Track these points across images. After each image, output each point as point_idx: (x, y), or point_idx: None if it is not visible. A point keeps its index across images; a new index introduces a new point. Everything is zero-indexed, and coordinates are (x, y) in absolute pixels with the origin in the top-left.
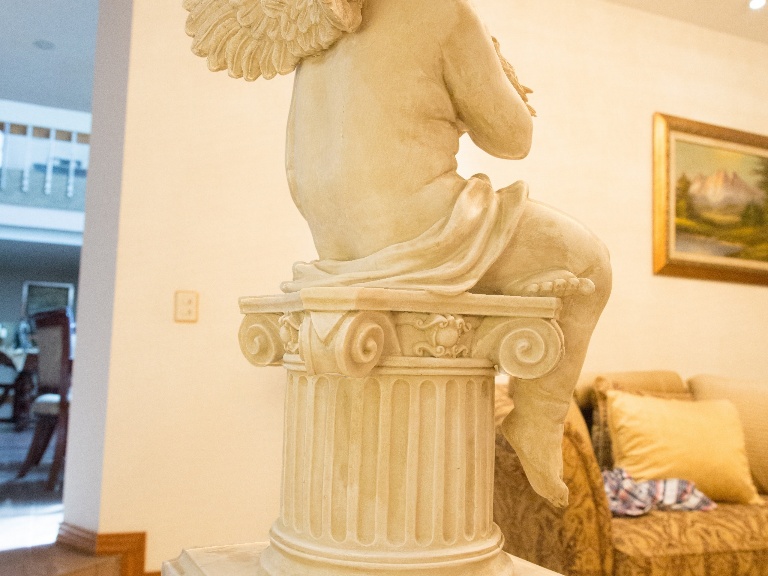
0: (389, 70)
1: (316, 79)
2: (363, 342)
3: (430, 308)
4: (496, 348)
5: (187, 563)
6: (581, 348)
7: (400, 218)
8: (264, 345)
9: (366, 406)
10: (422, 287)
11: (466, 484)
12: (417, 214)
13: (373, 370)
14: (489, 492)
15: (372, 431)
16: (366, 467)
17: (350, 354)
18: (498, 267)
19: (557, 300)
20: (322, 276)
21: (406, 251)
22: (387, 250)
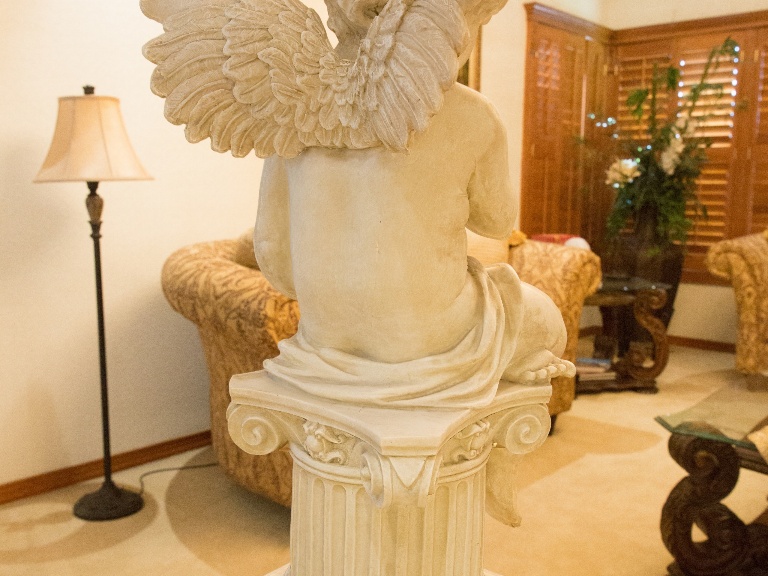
0: (432, 190)
1: (334, 176)
2: None
3: (470, 421)
4: (501, 432)
5: None
6: None
7: (433, 332)
8: (265, 436)
9: (411, 512)
10: (466, 406)
11: None
12: (449, 327)
13: None
14: None
15: (416, 532)
16: (411, 564)
17: None
18: None
19: None
20: (336, 374)
21: (443, 367)
22: (422, 364)
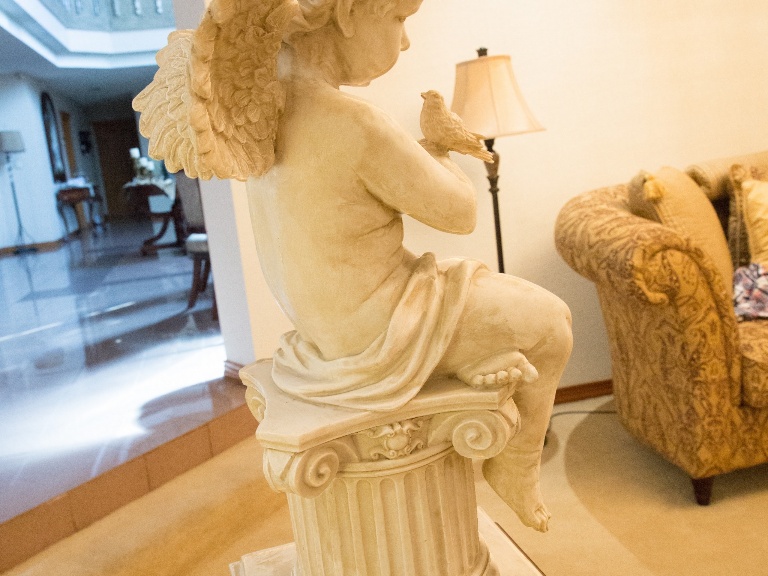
0: (309, 203)
1: (256, 193)
2: (315, 470)
3: (377, 423)
4: (450, 435)
5: (243, 575)
6: (543, 408)
7: (345, 334)
8: None
9: (338, 500)
10: (366, 408)
11: (437, 547)
12: (359, 330)
13: (337, 474)
14: (468, 536)
15: (346, 519)
16: (346, 546)
17: (305, 483)
18: (446, 361)
19: (500, 393)
20: (297, 366)
21: (352, 368)
22: (337, 364)
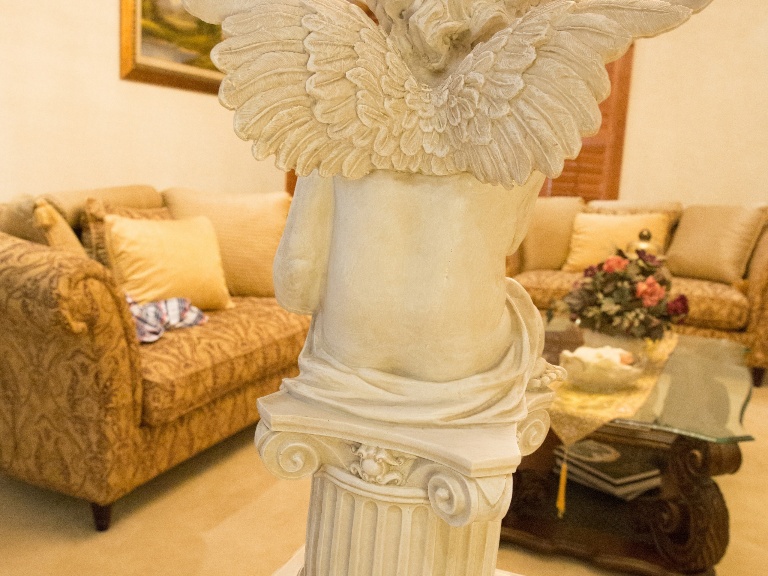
0: (499, 217)
1: (403, 200)
2: None
3: None
4: None
5: None
6: None
7: (483, 351)
8: None
9: None
10: (514, 420)
11: None
12: (494, 345)
13: None
14: None
15: (462, 542)
16: (456, 572)
17: None
18: None
19: None
20: (382, 395)
21: (492, 384)
22: (473, 382)
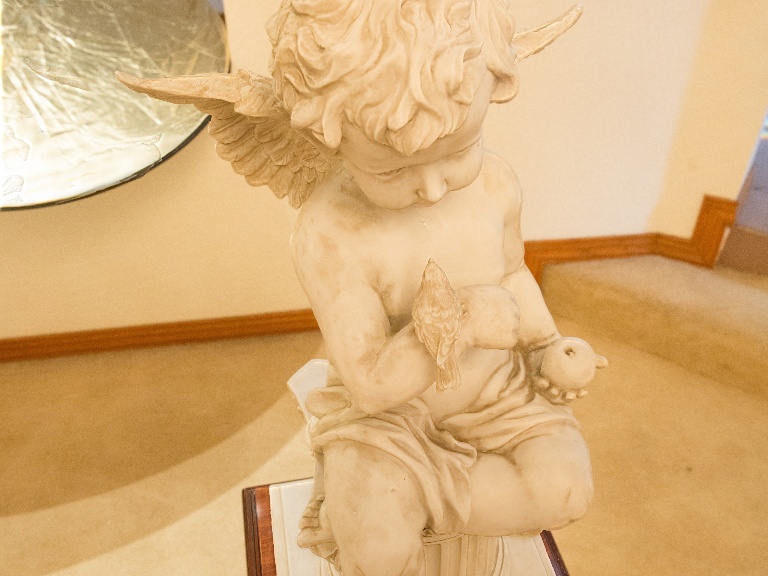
0: None
1: None
2: None
3: None
4: None
5: None
6: None
7: None
8: None
9: None
10: None
11: None
12: None
13: None
14: None
15: None
16: None
17: None
18: None
19: None
20: None
21: None
22: None
